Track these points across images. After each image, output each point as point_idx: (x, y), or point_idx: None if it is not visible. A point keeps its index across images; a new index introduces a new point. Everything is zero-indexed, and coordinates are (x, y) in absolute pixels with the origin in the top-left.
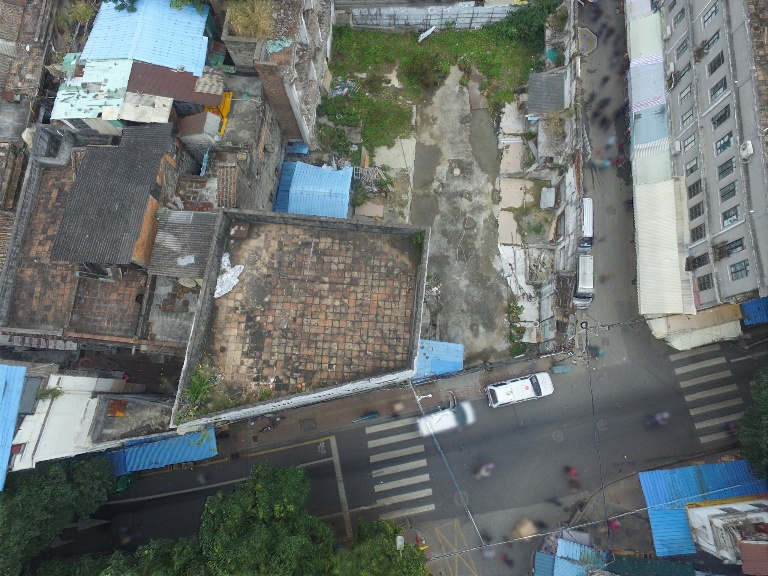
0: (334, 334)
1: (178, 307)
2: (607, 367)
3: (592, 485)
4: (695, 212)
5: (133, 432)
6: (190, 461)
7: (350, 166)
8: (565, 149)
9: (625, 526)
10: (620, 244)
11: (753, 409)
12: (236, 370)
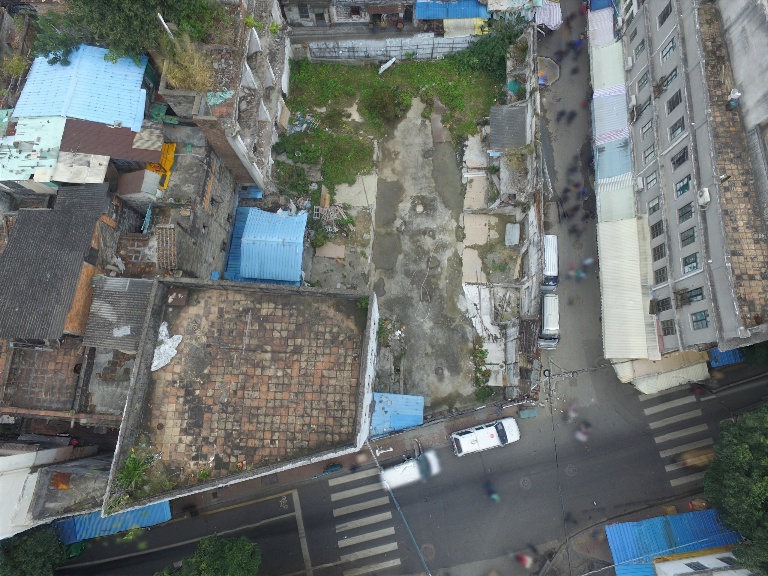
0: (276, 407)
1: (119, 375)
2: (575, 409)
3: (561, 534)
4: (658, 253)
5: (77, 505)
6: (143, 527)
7: (306, 210)
8: (527, 186)
9: (595, 575)
10: (587, 280)
11: (718, 461)
12: (174, 449)
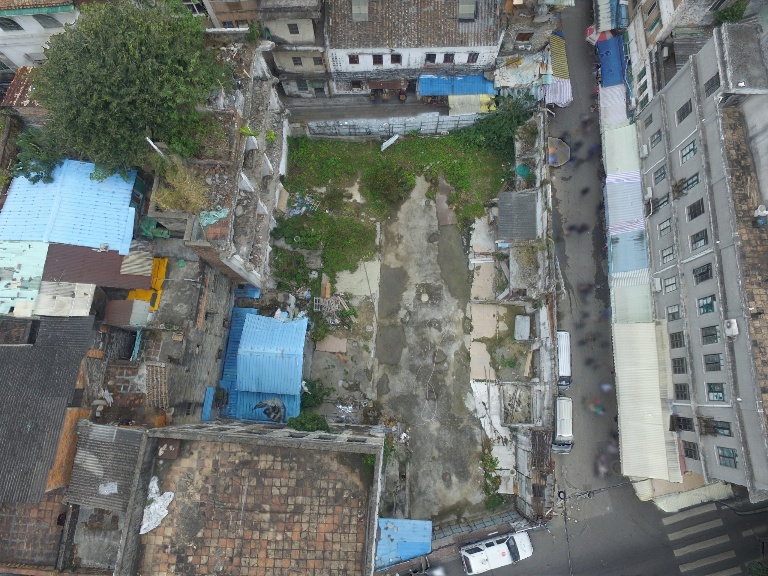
0: None
1: (106, 524)
2: (590, 519)
3: None
4: (678, 366)
5: None
6: None
7: (306, 311)
8: (538, 281)
9: None
10: (601, 375)
11: None
12: None
